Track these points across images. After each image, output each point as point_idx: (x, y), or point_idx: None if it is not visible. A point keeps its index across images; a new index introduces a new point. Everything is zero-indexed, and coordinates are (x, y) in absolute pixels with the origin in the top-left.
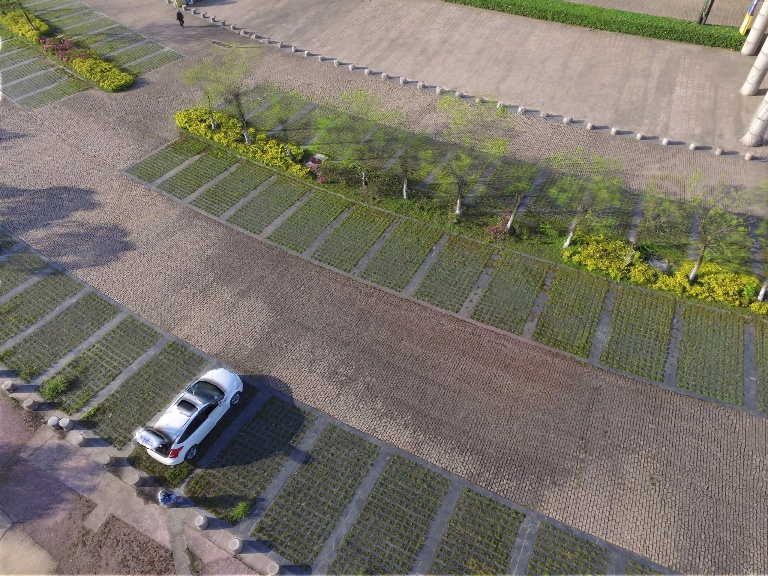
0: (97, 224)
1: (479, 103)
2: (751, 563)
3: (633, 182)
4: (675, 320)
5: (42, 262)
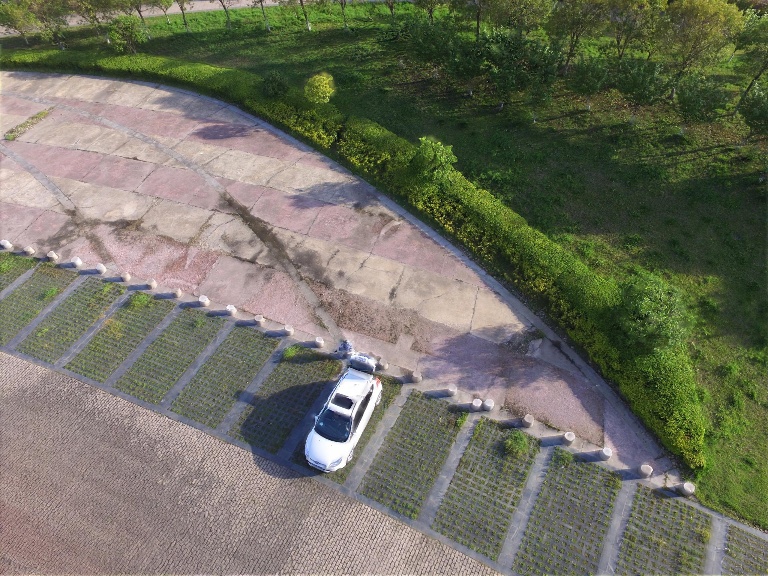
0: None
1: None
2: None
3: None
4: None
5: None
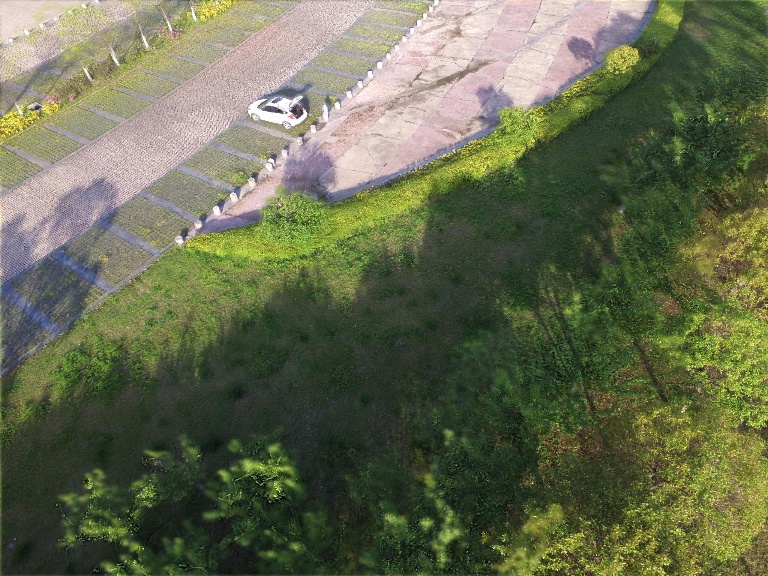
0: (49, 212)
1: (15, 41)
2: (362, 3)
3: (151, 1)
4: (256, 2)
5: (90, 231)
